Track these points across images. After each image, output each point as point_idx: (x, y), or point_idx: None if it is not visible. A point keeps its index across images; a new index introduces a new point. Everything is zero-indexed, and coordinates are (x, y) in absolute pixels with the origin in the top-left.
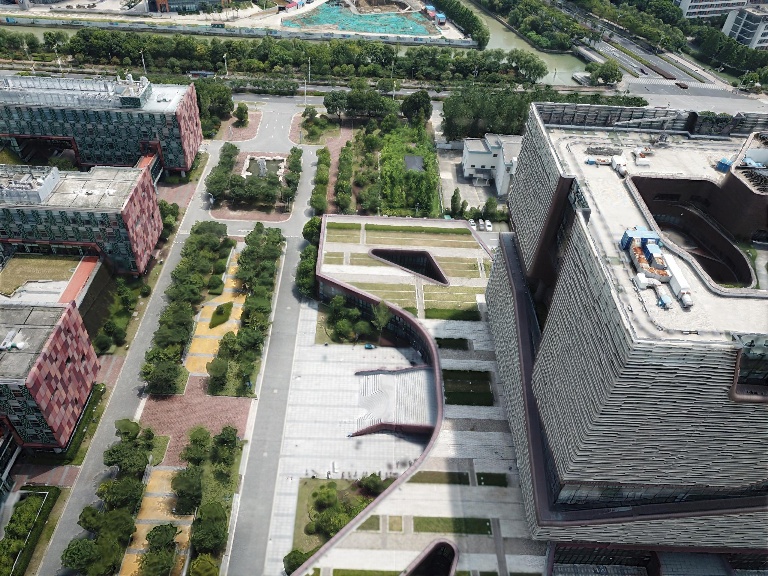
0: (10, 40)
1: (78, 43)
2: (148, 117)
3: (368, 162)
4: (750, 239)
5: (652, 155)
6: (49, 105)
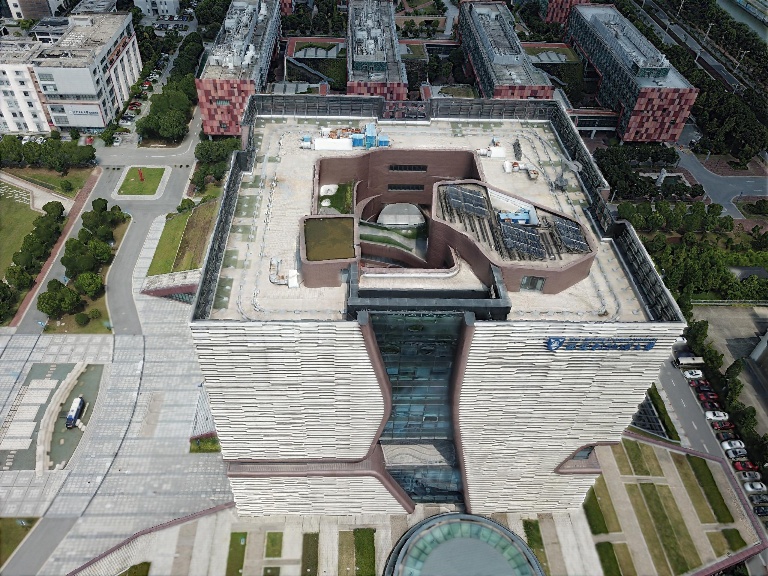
0: (745, 40)
1: (767, 60)
2: (631, 84)
3: (732, 245)
4: (427, 235)
5: (530, 179)
6: (609, 47)
